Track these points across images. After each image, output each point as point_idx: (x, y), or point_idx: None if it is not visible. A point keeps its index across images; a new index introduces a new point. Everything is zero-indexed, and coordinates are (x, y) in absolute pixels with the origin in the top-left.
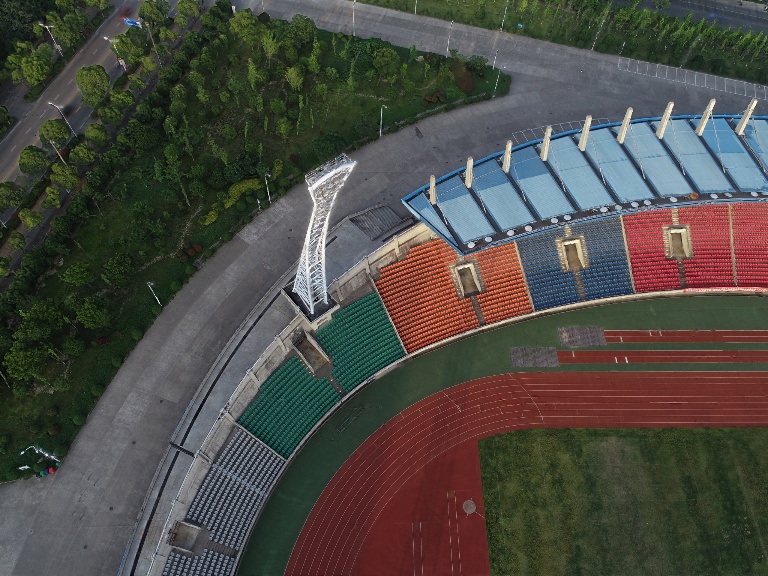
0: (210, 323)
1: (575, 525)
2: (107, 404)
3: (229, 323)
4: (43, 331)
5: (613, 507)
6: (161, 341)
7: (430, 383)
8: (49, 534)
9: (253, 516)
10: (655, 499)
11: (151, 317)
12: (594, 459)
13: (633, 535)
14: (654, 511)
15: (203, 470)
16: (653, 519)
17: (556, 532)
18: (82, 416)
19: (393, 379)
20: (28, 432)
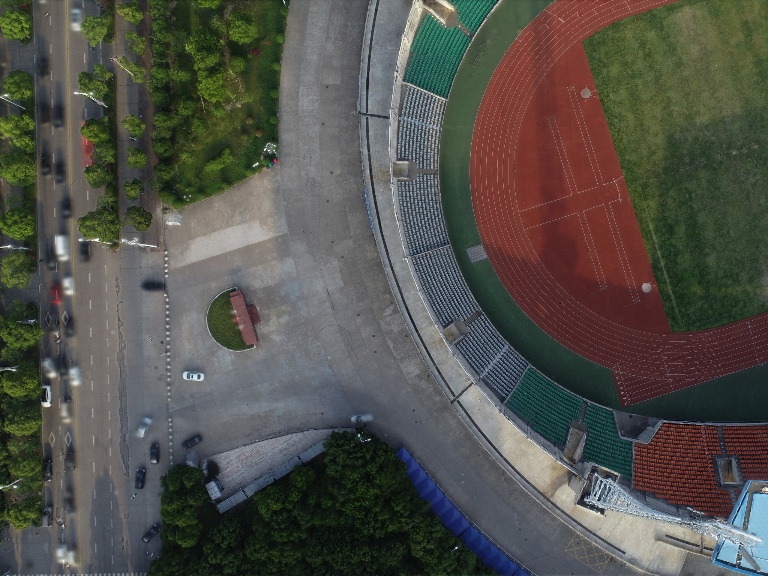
0: (334, 9)
1: (664, 83)
2: (287, 102)
3: (350, 4)
4: (215, 56)
5: (691, 61)
6: (301, 38)
7: (533, 6)
8: (298, 201)
9: (438, 145)
10: (721, 46)
11: (282, 19)
12: (673, 29)
13: (707, 77)
14: (721, 55)
15: (395, 123)
16: (720, 61)
17: (651, 92)
18: (276, 116)
19: (503, 11)
20: (241, 140)
